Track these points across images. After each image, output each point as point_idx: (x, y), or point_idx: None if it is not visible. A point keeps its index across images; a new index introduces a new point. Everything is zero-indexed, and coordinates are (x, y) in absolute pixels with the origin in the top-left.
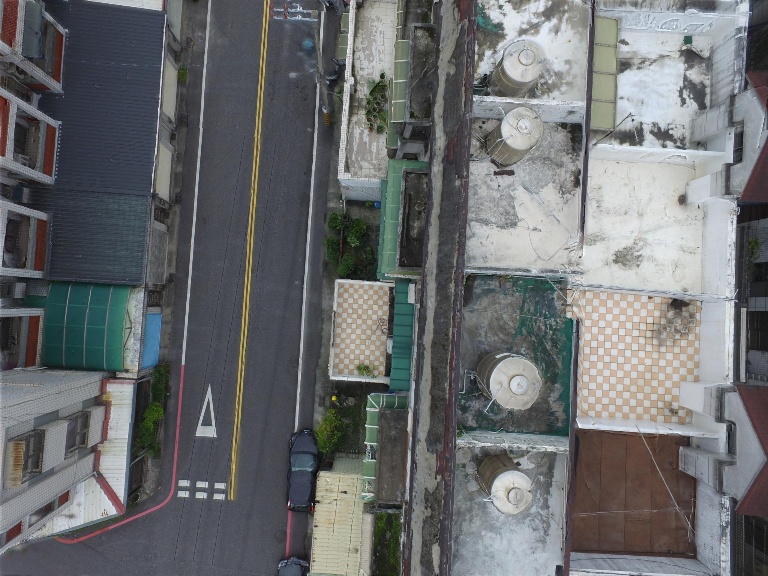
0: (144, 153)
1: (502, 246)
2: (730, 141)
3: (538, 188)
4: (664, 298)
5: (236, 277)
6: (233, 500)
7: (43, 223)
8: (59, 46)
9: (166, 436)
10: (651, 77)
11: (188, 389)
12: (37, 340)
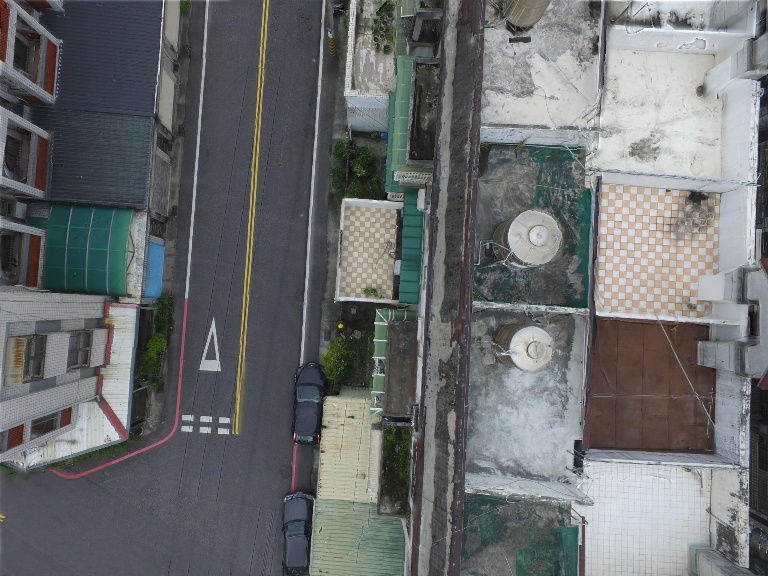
0: (147, 73)
1: (518, 115)
2: (752, 16)
3: (555, 55)
4: (682, 190)
5: (240, 210)
6: (238, 435)
7: (44, 142)
8: None
9: (169, 370)
10: None
11: (192, 323)
12: (38, 261)
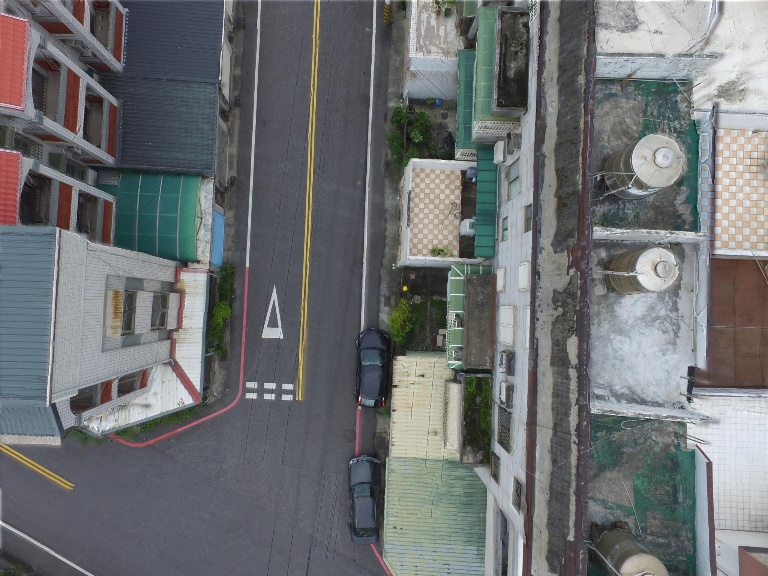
0: (211, 40)
1: (622, 50)
2: None
3: None
4: None
5: (298, 178)
6: (301, 400)
7: (114, 109)
8: None
9: (232, 338)
10: None
11: (253, 291)
12: (111, 227)
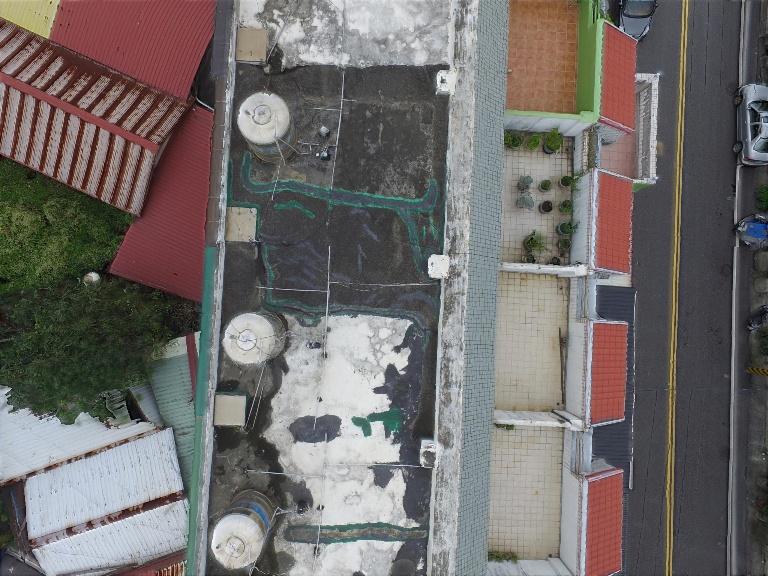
0: (620, 445)
1: None
2: None
3: None
4: None
5: (655, 539)
6: None
7: None
8: None
9: None
10: None
11: None
12: None
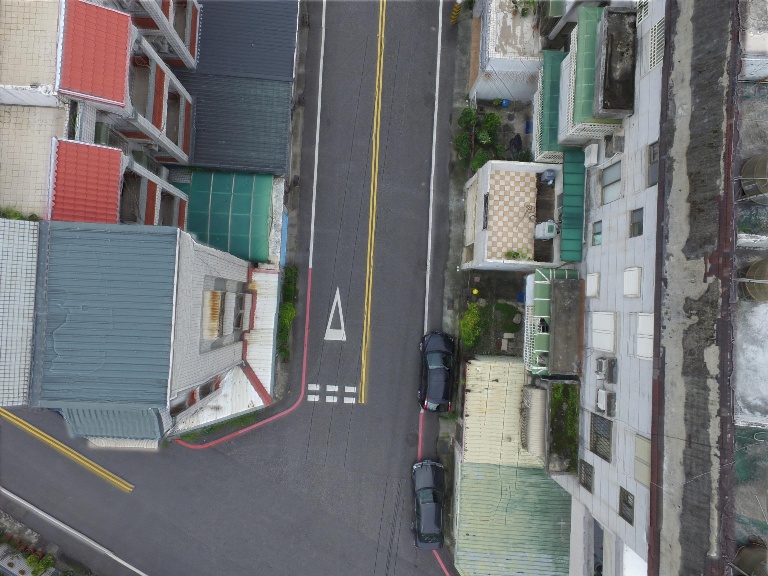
0: (285, 38)
1: (755, 52)
2: None
3: None
4: None
5: (362, 179)
6: (364, 404)
7: (188, 106)
8: None
9: (294, 340)
10: None
11: (315, 292)
12: (183, 226)
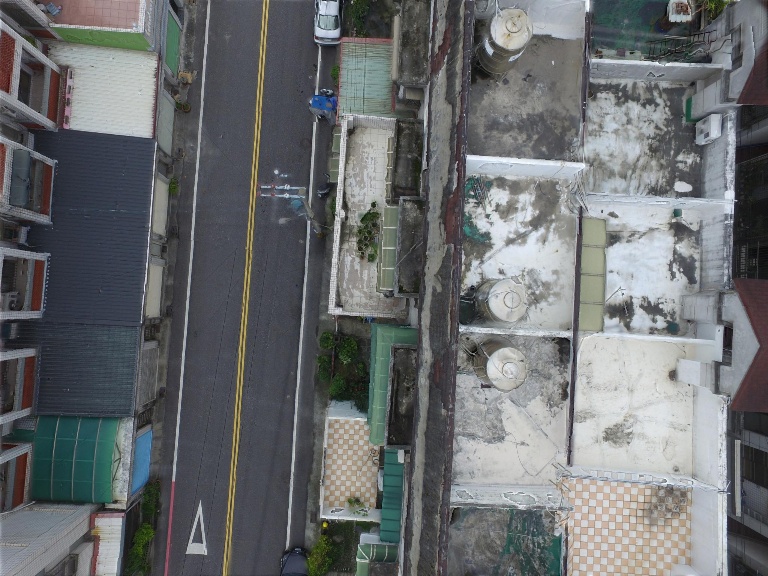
0: (134, 283)
1: (489, 461)
2: (719, 338)
3: (526, 401)
4: (655, 477)
5: (227, 391)
6: None
7: (31, 359)
8: (48, 178)
9: (156, 554)
10: (641, 250)
11: (178, 506)
12: (24, 477)
